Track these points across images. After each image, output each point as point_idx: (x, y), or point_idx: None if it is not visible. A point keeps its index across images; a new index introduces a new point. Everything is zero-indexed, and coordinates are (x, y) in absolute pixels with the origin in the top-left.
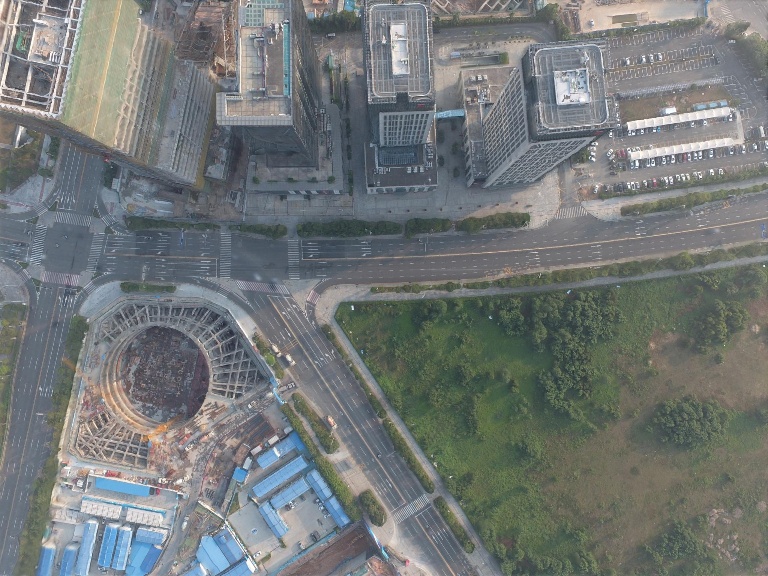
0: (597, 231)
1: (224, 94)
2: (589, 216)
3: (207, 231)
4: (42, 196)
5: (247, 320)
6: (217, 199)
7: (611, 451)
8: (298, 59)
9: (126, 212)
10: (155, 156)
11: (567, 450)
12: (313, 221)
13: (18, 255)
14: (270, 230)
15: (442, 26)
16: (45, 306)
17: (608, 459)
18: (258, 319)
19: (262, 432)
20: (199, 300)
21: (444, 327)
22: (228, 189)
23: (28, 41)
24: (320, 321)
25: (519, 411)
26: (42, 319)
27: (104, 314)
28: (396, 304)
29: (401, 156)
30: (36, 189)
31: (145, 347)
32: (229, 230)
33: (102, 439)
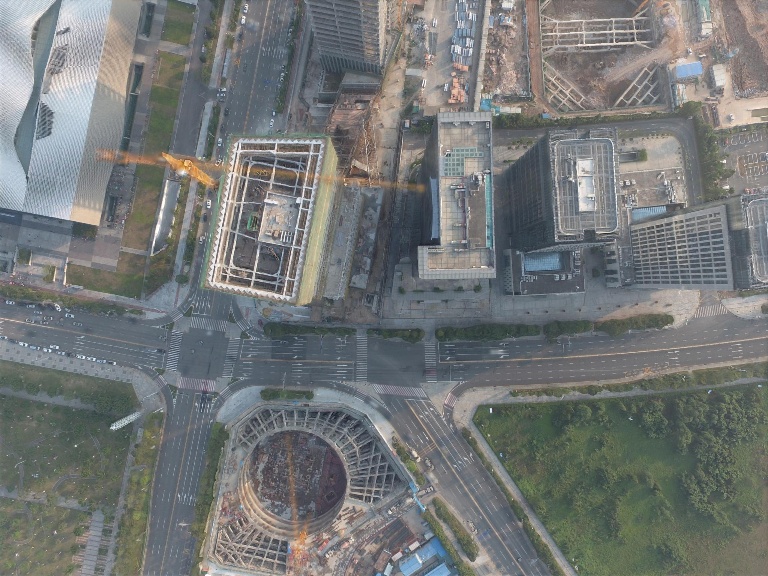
0: (737, 329)
1: (426, 247)
2: (729, 314)
3: (346, 336)
4: (177, 301)
5: (385, 424)
6: (353, 302)
7: (754, 553)
8: None
9: (262, 317)
10: (325, 287)
11: (709, 552)
12: (450, 323)
13: (154, 361)
14: (412, 337)
15: (580, 124)
16: (182, 412)
17: (751, 561)
18: (396, 423)
19: (402, 537)
20: (336, 404)
21: (583, 429)
22: (364, 292)
23: (258, 221)
24: (458, 424)
25: (662, 515)
26: (179, 425)
27: (241, 420)
28: (535, 406)
29: (546, 262)
30: (171, 294)
31: (273, 445)
32: (366, 334)
33: (240, 545)
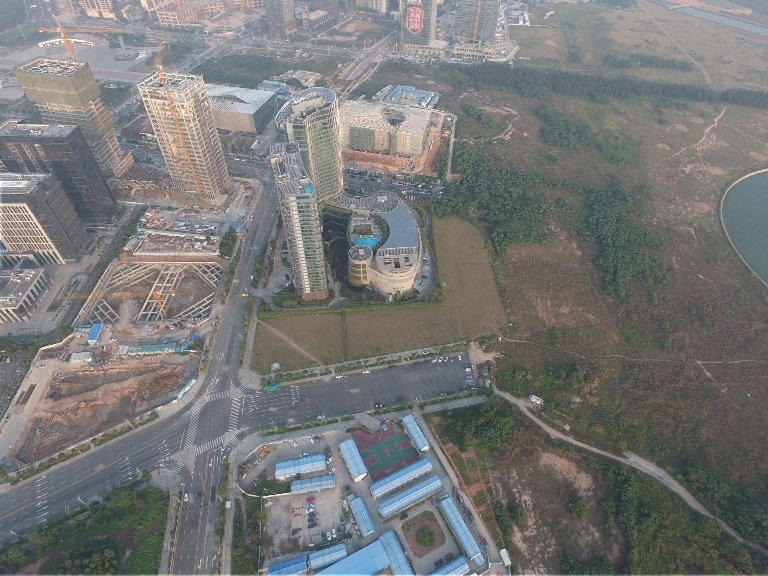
0: None
1: None
2: None
3: None
4: None
5: None
6: None
7: None
8: (40, 155)
9: None
10: None
11: None
12: None
13: None
14: None
15: None
16: None
17: None
18: None
19: None
20: None
21: None
22: None
23: None
24: None
25: None
26: None
27: None
28: None
29: None
30: None
31: None
32: None
33: None
